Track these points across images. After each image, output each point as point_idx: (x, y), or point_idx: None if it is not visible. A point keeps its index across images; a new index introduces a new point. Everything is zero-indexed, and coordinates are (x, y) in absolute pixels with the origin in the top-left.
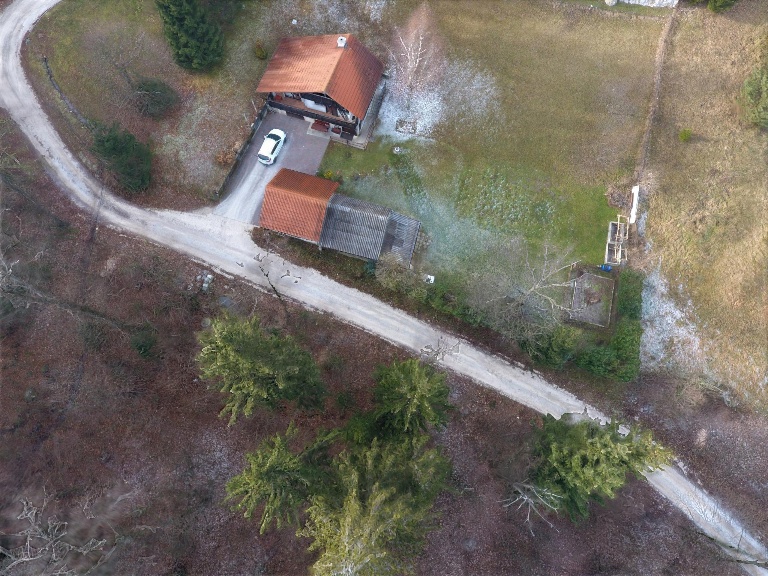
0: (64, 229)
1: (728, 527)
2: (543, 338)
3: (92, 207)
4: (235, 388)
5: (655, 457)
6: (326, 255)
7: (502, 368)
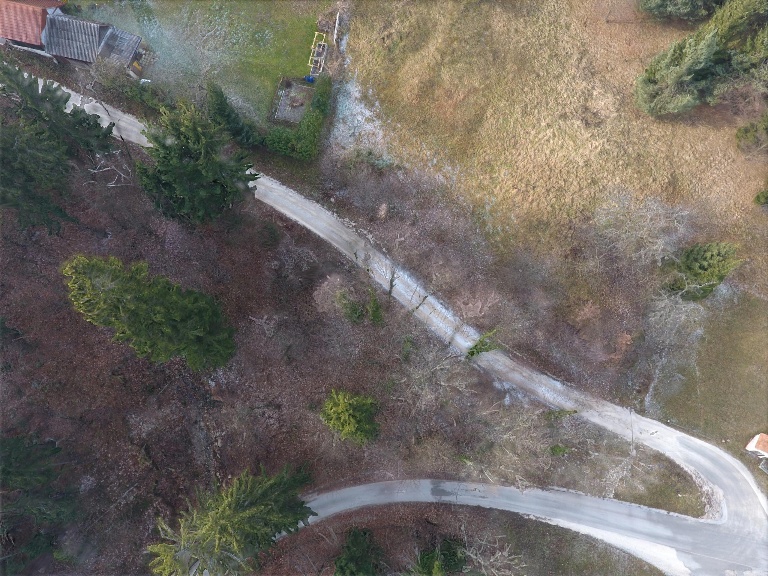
0: None
1: (405, 283)
2: None
3: None
4: None
5: None
6: (62, 67)
7: None
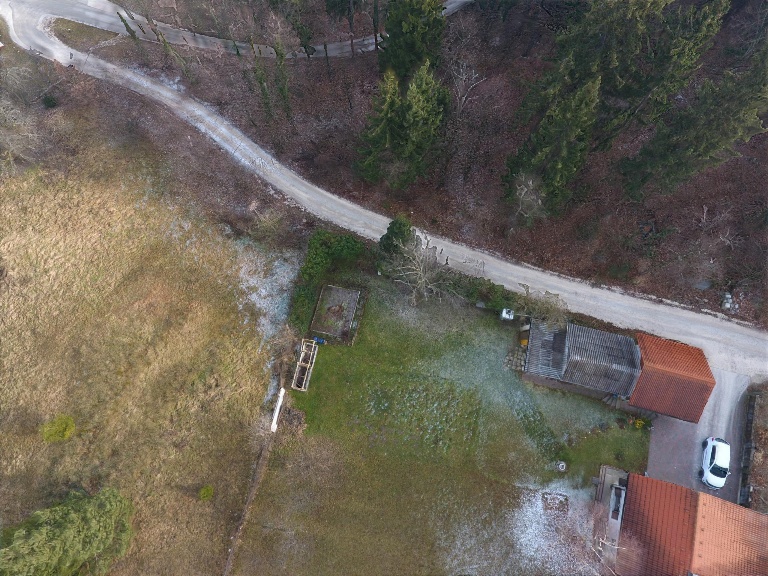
0: None
1: (245, 155)
2: None
3: None
4: None
5: None
6: None
7: None
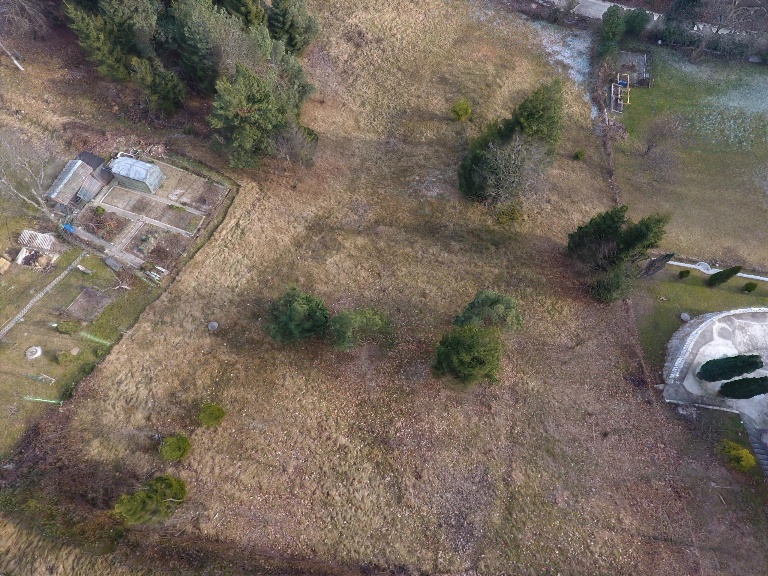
0: None
1: None
2: None
3: None
4: None
5: None
6: None
7: None
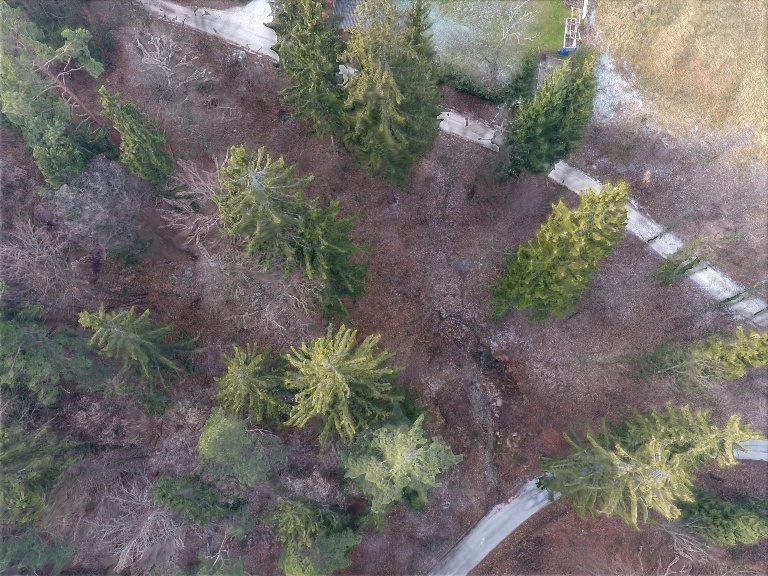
0: (123, 18)
1: (672, 246)
2: (513, 75)
3: (144, 5)
4: (286, 3)
5: (589, 67)
6: None
7: (484, 129)
